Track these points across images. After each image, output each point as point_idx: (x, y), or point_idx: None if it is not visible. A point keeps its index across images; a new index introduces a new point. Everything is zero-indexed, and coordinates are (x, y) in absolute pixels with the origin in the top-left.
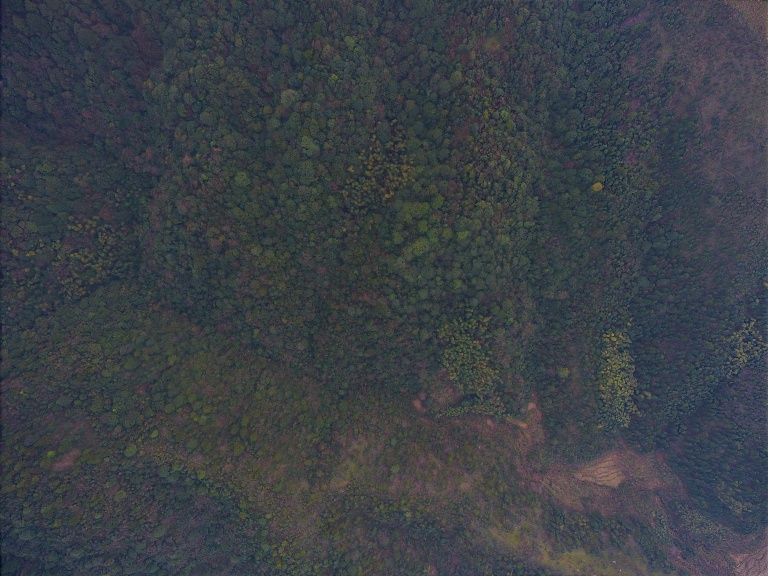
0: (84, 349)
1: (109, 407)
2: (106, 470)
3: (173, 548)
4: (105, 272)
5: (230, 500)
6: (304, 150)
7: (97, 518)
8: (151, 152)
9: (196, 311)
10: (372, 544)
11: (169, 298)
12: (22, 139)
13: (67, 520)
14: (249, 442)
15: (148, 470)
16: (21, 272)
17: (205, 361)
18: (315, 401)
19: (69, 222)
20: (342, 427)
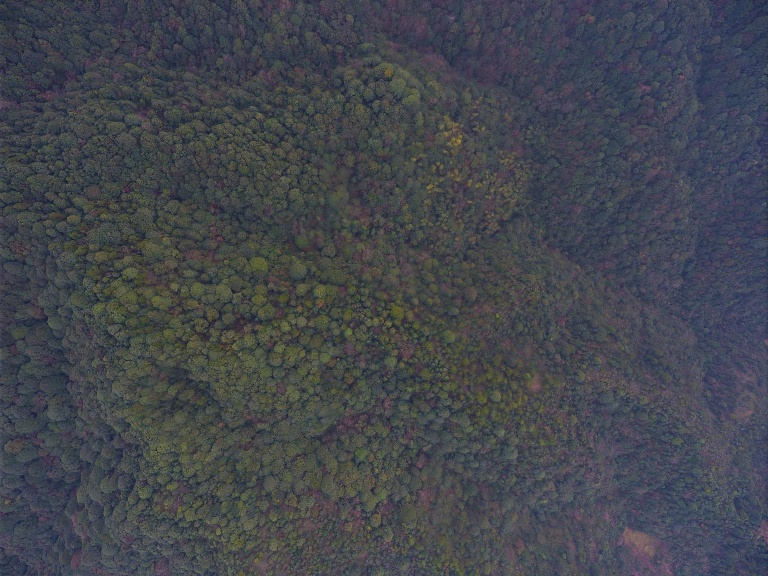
0: (525, 279)
1: (546, 336)
2: (562, 395)
3: (598, 476)
4: (517, 208)
5: (665, 426)
6: (764, 77)
7: (565, 440)
8: (572, 88)
9: (580, 249)
10: (759, 476)
11: (560, 236)
12: (455, 75)
13: (547, 440)
14: (669, 371)
15: (592, 396)
16: (463, 204)
17: (595, 297)
18: (690, 338)
19: (498, 156)
20: (727, 361)
